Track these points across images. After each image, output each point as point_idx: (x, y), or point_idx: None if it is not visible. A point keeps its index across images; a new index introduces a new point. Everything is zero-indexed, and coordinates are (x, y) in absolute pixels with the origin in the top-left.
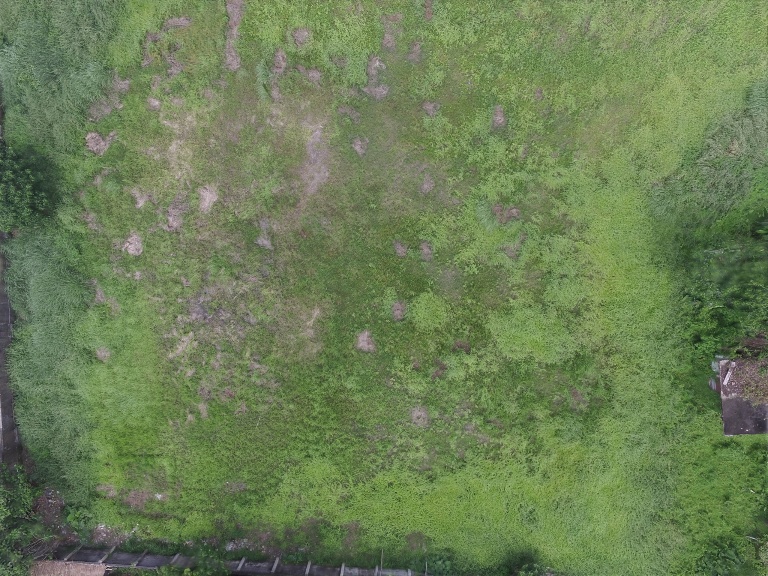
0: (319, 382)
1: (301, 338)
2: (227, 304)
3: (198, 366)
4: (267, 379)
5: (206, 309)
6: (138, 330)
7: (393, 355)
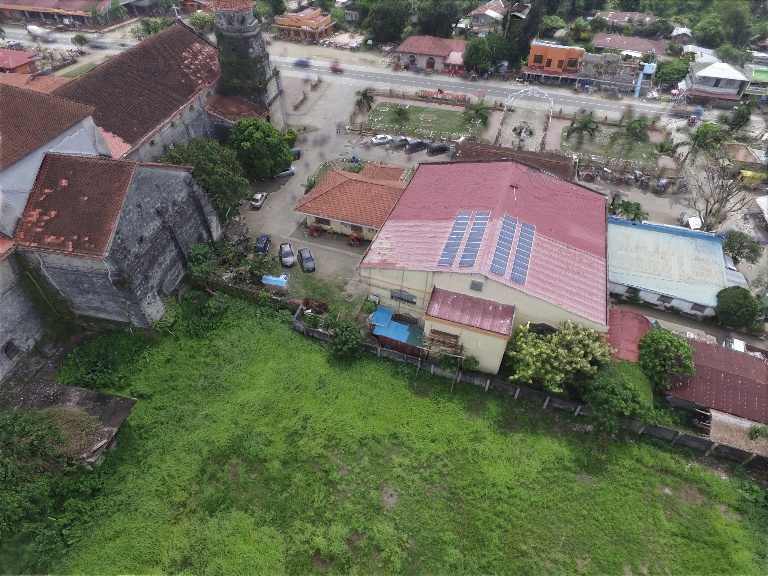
0: (490, 568)
1: None
2: None
3: None
4: None
5: None
6: None
7: (400, 575)
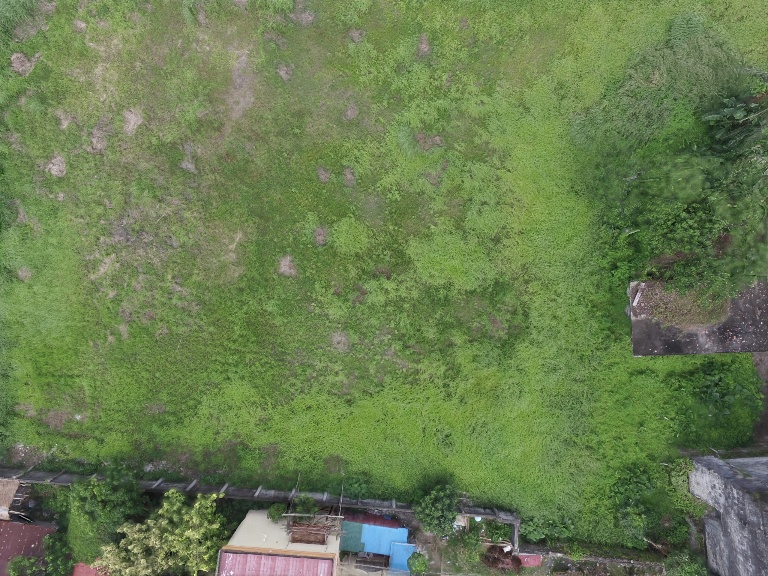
0: (240, 306)
1: (223, 261)
2: (150, 227)
3: (120, 288)
4: (188, 302)
5: (129, 232)
6: (60, 250)
7: (314, 280)
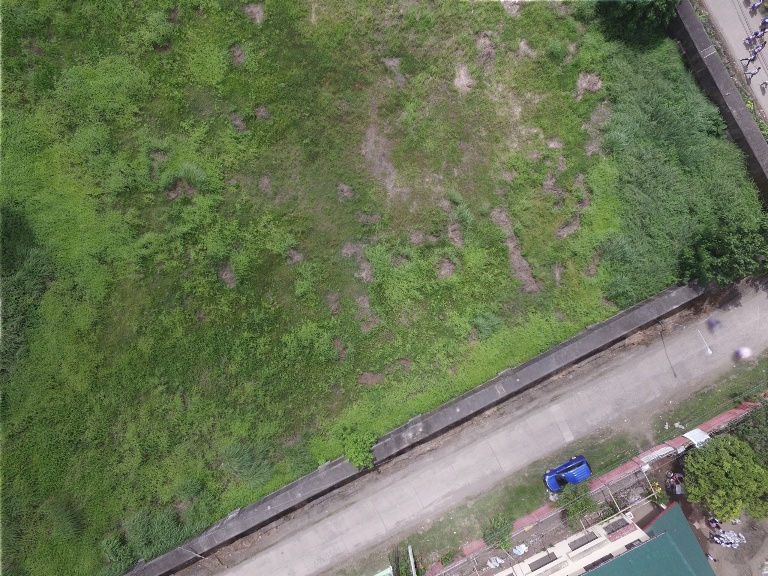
0: None
1: None
2: None
3: None
4: None
5: None
6: None
7: (224, 11)
